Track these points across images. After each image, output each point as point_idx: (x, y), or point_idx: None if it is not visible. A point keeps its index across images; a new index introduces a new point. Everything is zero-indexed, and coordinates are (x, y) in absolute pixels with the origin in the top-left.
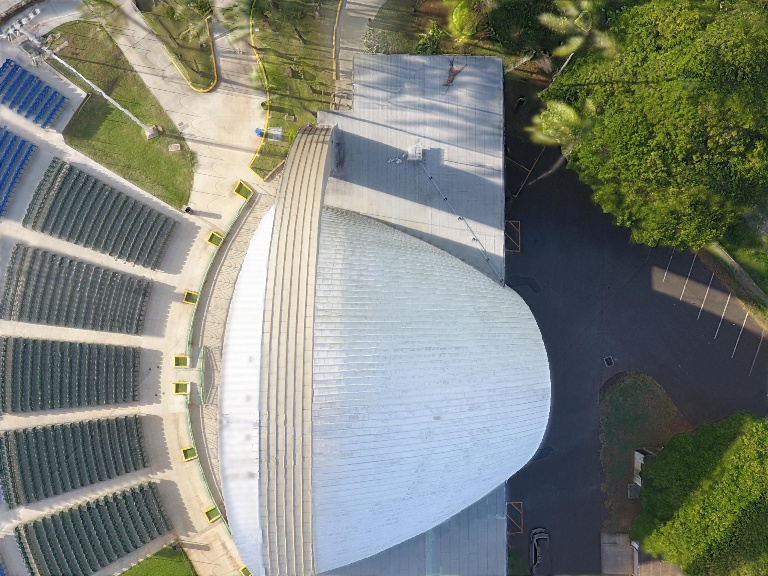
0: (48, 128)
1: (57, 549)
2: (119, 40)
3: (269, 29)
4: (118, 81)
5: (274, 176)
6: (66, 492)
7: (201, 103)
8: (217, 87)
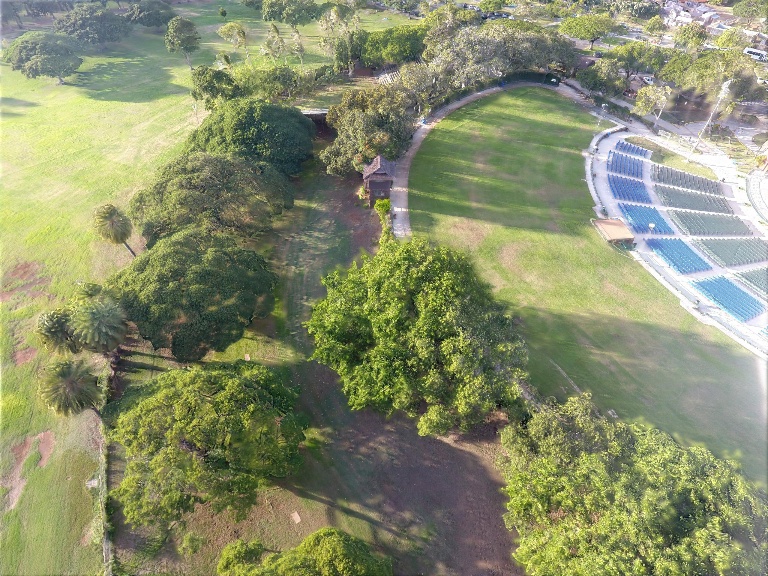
0: (644, 158)
1: (764, 283)
2: (654, 141)
3: (712, 141)
4: (661, 150)
5: (751, 174)
6: (746, 264)
7: (700, 156)
8: (703, 153)
